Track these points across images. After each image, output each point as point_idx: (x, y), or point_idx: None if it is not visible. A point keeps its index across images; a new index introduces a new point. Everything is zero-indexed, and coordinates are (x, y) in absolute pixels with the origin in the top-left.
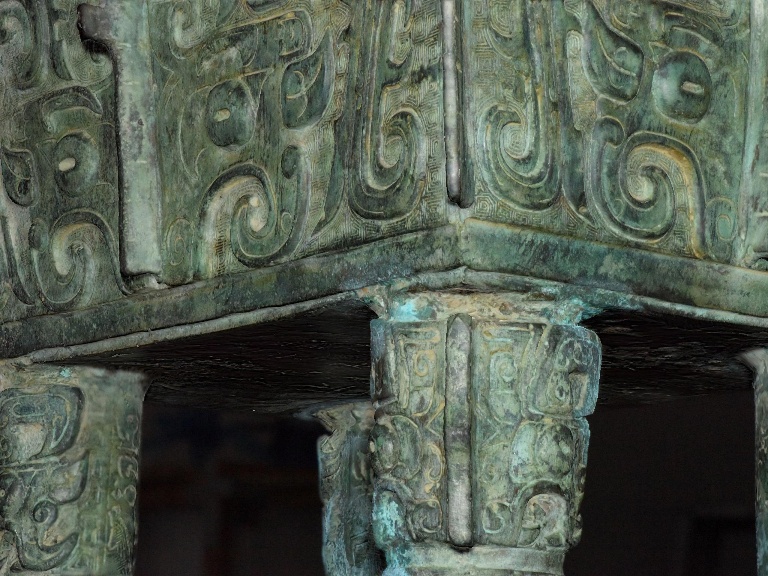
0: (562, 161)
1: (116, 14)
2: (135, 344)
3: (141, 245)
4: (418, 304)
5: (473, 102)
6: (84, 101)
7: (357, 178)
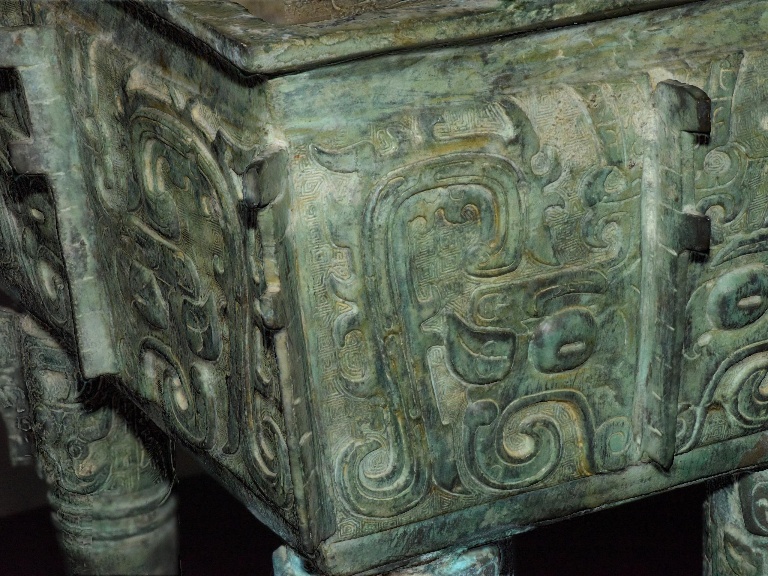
0: (430, 461)
1: (46, 147)
2: None
3: (97, 353)
4: (309, 562)
5: (328, 449)
6: None
7: (246, 445)
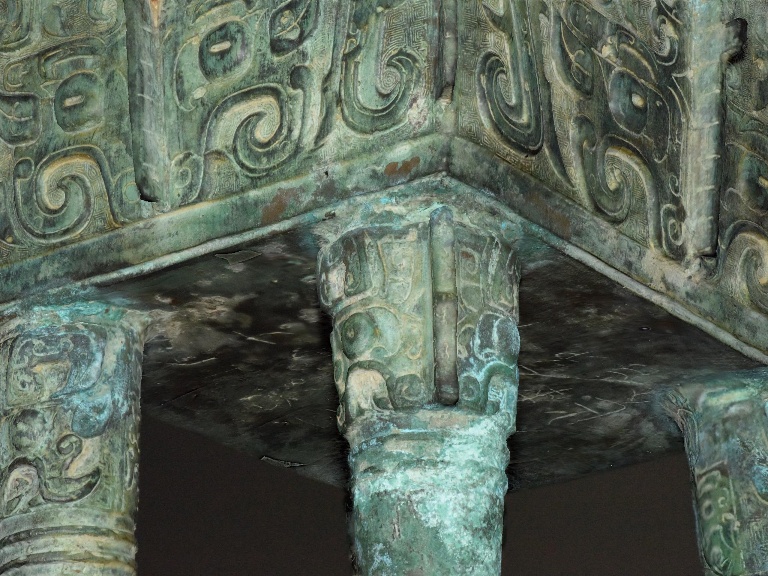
0: None
1: None
2: None
3: None
4: None
5: None
6: None
7: None
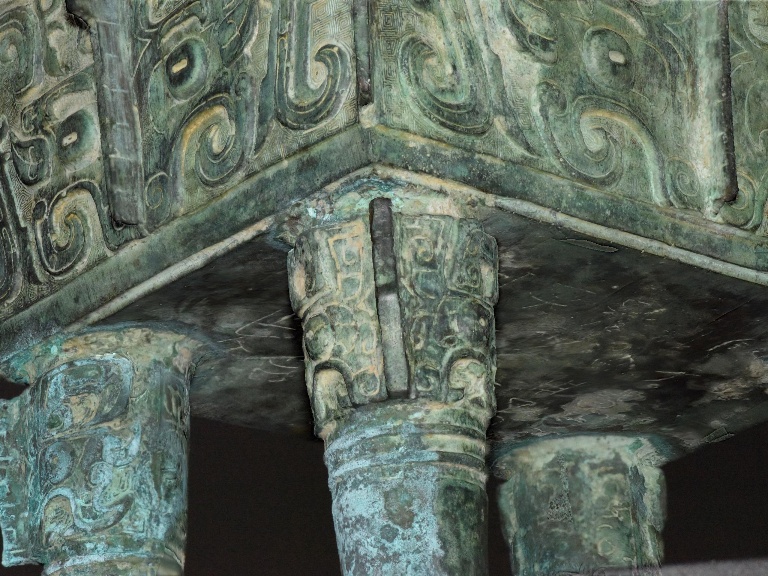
0: None
1: None
2: (642, 248)
3: None
4: None
5: None
6: (636, 13)
7: None
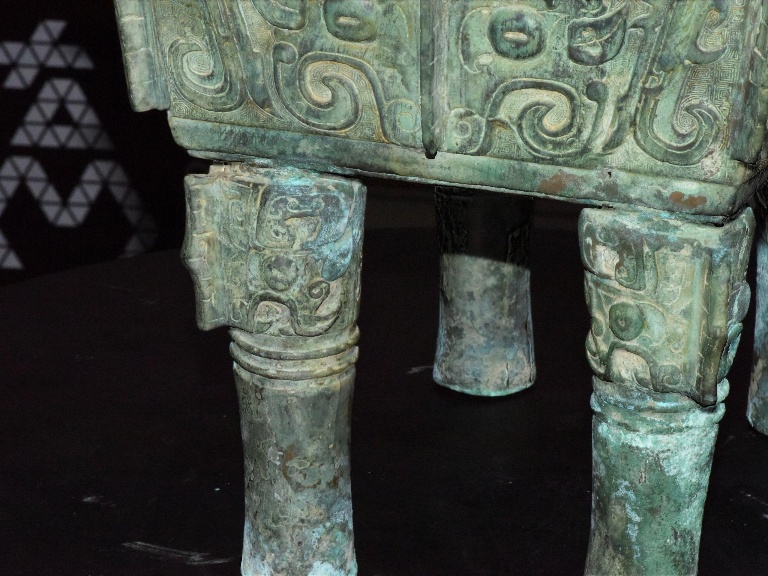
0: (241, 77)
1: None
2: None
3: None
4: None
5: (161, 37)
6: None
7: None
